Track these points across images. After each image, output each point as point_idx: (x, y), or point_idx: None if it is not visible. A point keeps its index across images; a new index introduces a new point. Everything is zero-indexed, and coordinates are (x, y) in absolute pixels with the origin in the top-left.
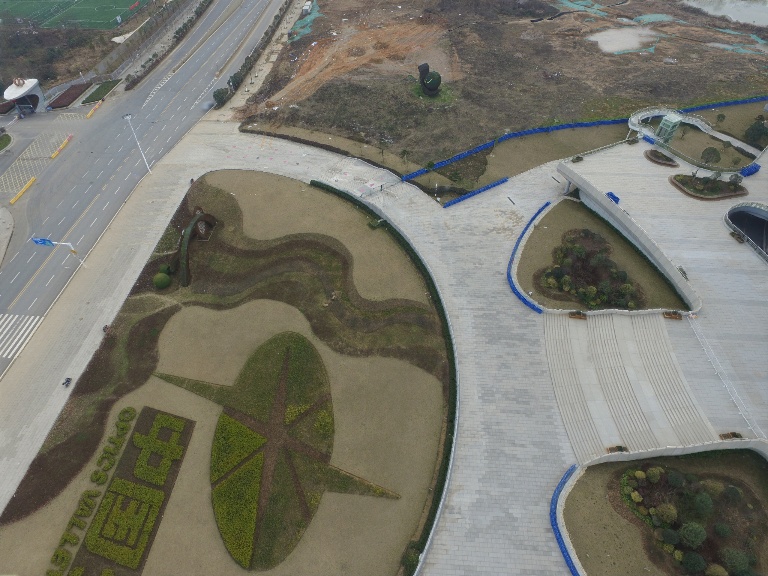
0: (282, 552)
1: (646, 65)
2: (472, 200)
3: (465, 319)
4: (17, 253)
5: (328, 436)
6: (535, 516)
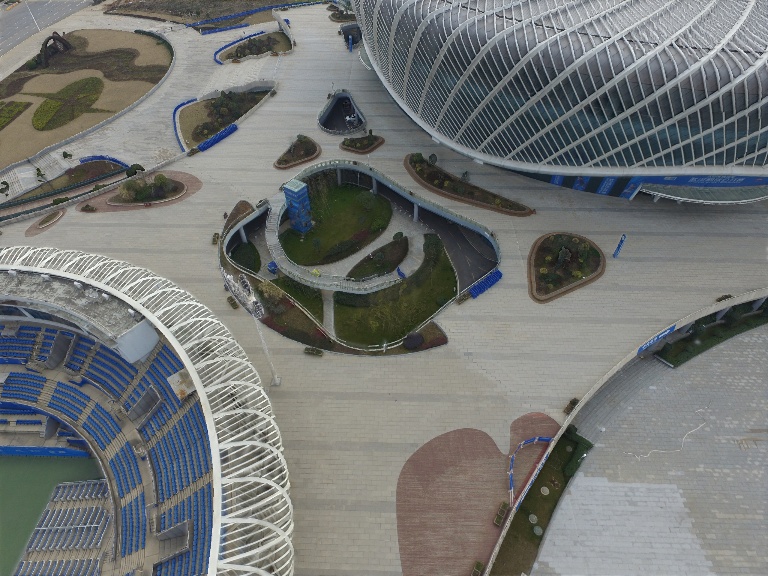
0: (58, 126)
1: None
2: (221, 32)
3: (181, 67)
4: None
5: (93, 100)
6: (169, 111)
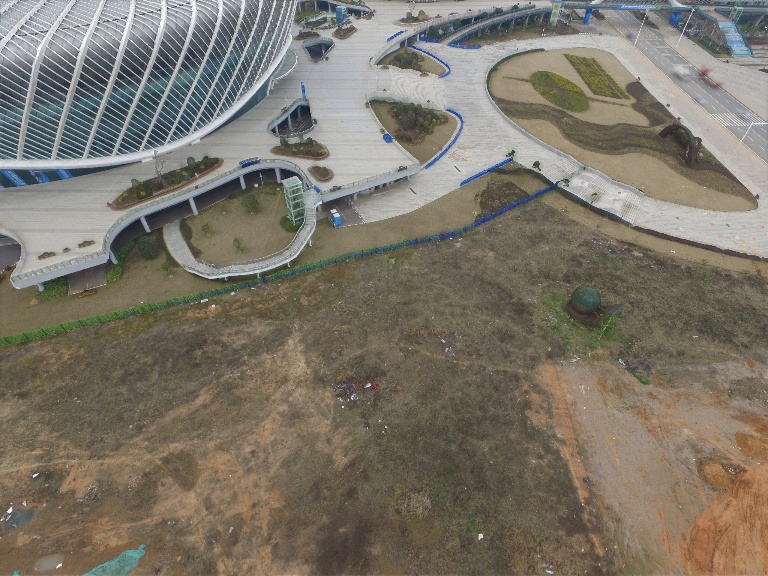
0: None
1: (124, 458)
2: None
3: (487, 108)
4: None
5: None
6: None
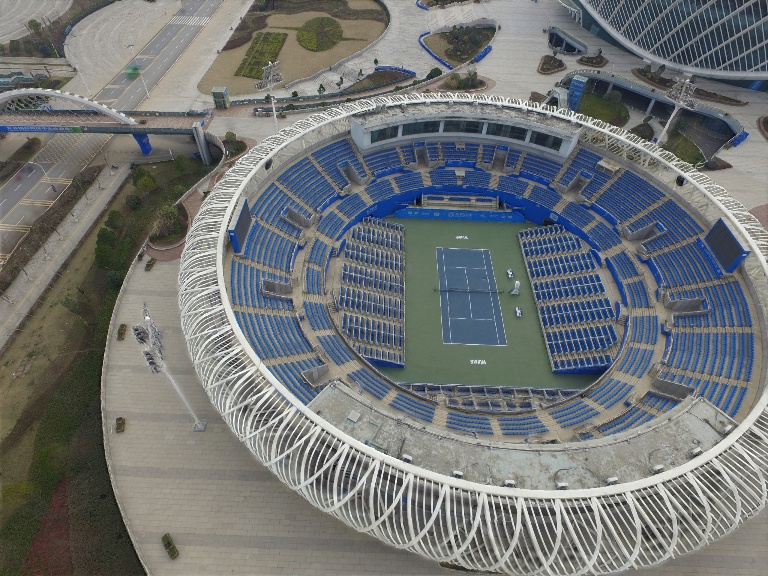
0: None
1: None
2: None
3: (396, 11)
4: (187, 3)
5: (341, 32)
6: (413, 40)
